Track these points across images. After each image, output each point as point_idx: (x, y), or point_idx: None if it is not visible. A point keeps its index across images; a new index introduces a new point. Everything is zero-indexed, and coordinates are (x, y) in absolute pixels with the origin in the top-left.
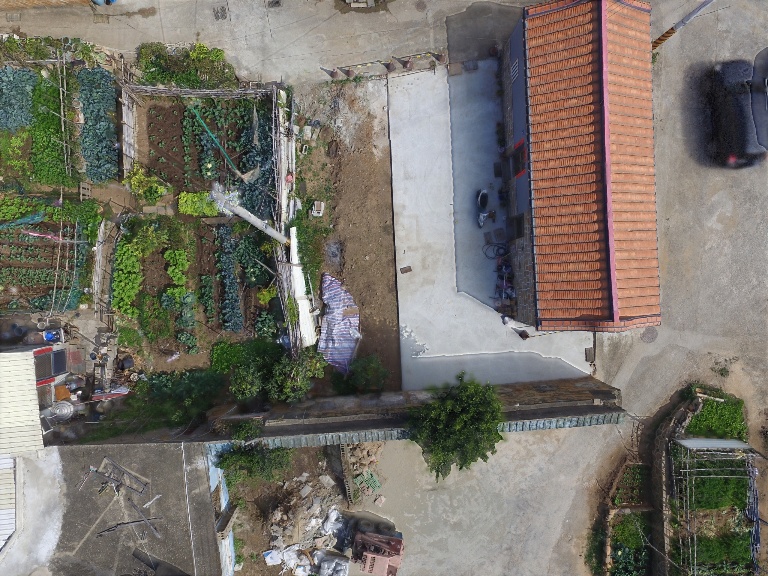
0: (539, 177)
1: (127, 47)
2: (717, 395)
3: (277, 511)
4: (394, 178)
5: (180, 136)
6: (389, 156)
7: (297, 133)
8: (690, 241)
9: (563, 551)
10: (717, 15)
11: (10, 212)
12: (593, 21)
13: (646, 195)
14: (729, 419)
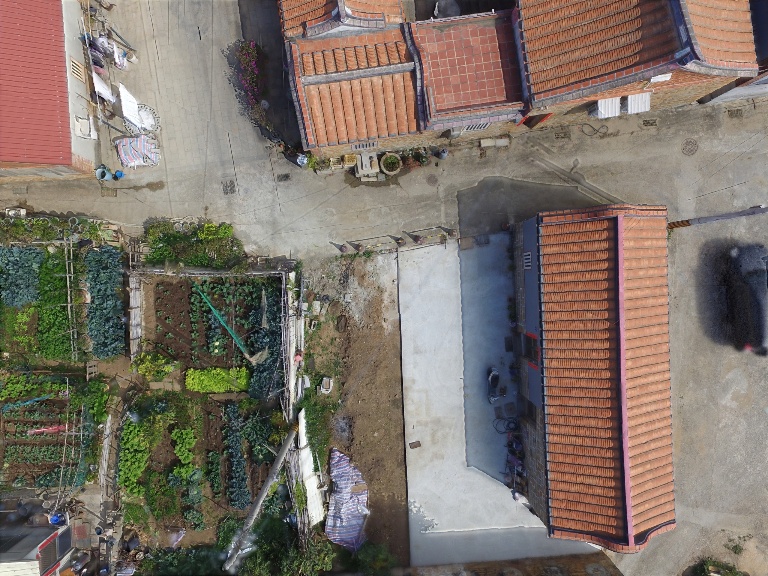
0: (552, 384)
1: (134, 221)
2: (730, 575)
3: None
4: (404, 352)
5: (187, 311)
6: (399, 329)
7: (306, 309)
8: (704, 419)
9: None
10: (733, 191)
11: (16, 390)
12: (609, 239)
13: (661, 402)
14: None
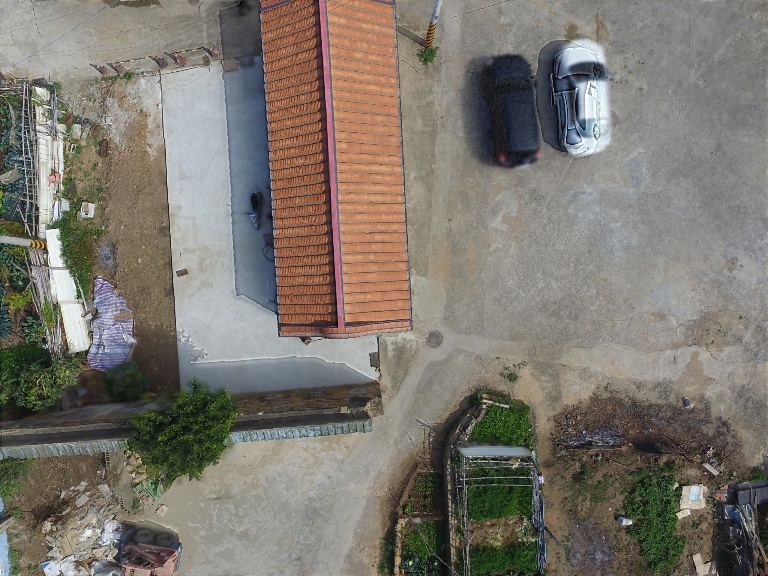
0: (277, 177)
1: None
2: (502, 401)
3: (47, 522)
4: (169, 178)
5: None
6: (164, 155)
7: (64, 132)
8: (473, 242)
9: (355, 561)
10: (500, 8)
11: None
12: (315, 14)
13: (390, 195)
14: (513, 426)
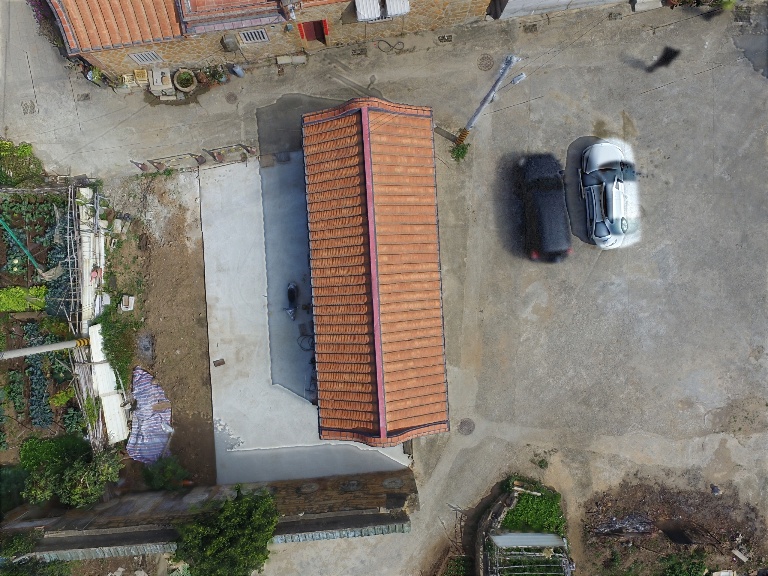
0: (318, 285)
1: None
2: (534, 489)
3: None
4: (206, 270)
5: None
6: (202, 248)
7: (105, 227)
8: (505, 333)
9: None
10: (529, 105)
11: None
12: (358, 134)
13: (428, 302)
14: (545, 514)
